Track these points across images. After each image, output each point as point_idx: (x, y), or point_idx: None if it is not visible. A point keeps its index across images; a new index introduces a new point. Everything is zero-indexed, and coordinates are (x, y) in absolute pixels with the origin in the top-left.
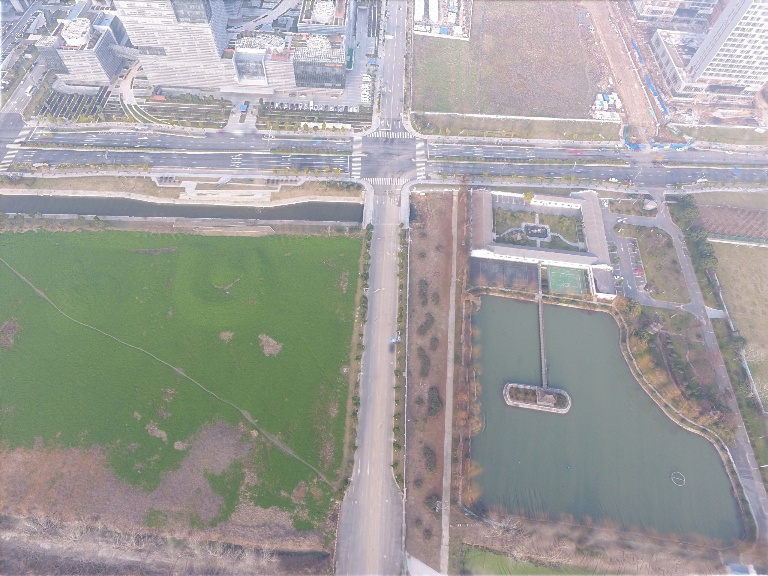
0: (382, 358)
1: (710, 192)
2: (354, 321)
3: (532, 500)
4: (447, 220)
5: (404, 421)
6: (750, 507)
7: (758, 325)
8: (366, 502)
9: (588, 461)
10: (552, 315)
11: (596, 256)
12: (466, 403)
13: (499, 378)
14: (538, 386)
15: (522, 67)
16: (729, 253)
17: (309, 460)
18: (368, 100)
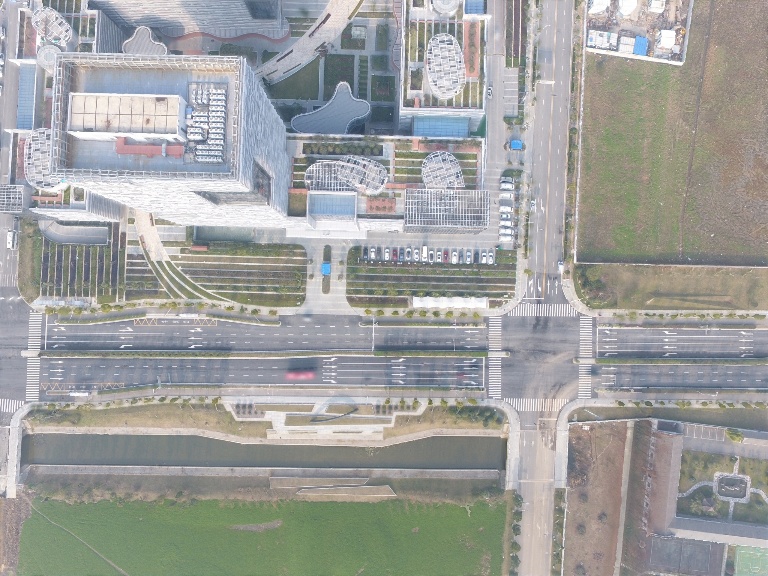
0: None
1: None
2: None
3: None
4: (616, 472)
5: None
6: None
7: None
8: None
9: None
10: None
11: None
12: None
13: None
14: None
15: (765, 136)
16: None
17: None
18: (510, 239)
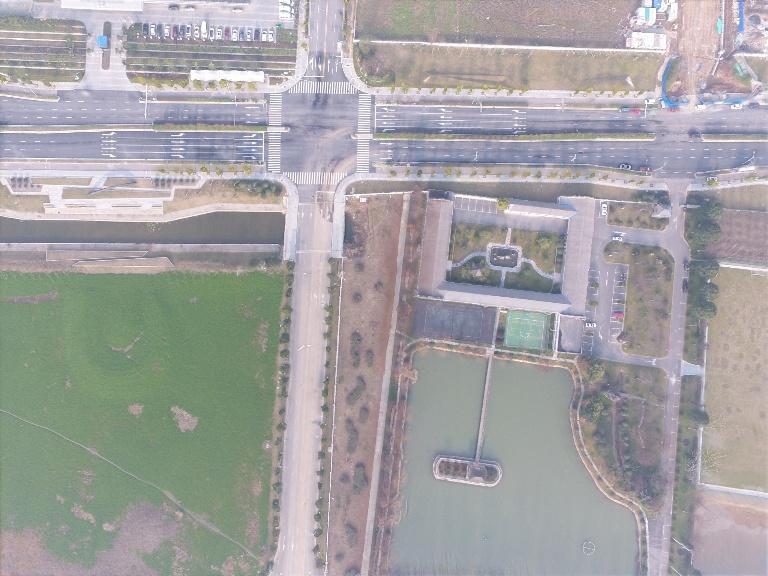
0: (307, 432)
1: (751, 186)
2: (276, 388)
3: (447, 561)
4: (392, 242)
5: (328, 499)
6: (648, 573)
7: (734, 384)
8: (290, 574)
9: (507, 530)
10: (501, 376)
11: (569, 302)
12: (385, 509)
13: (431, 450)
14: (471, 458)
15: None
16: (739, 285)
17: (235, 538)
18: (289, 16)
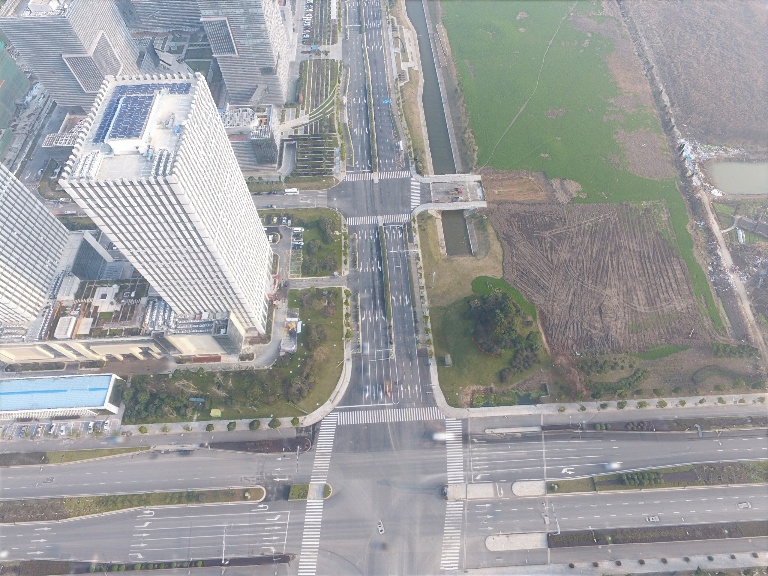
0: None
1: None
2: None
3: None
4: None
5: None
6: None
7: None
8: None
9: None
10: None
11: None
12: None
13: None
14: None
15: None
16: None
17: None
18: None
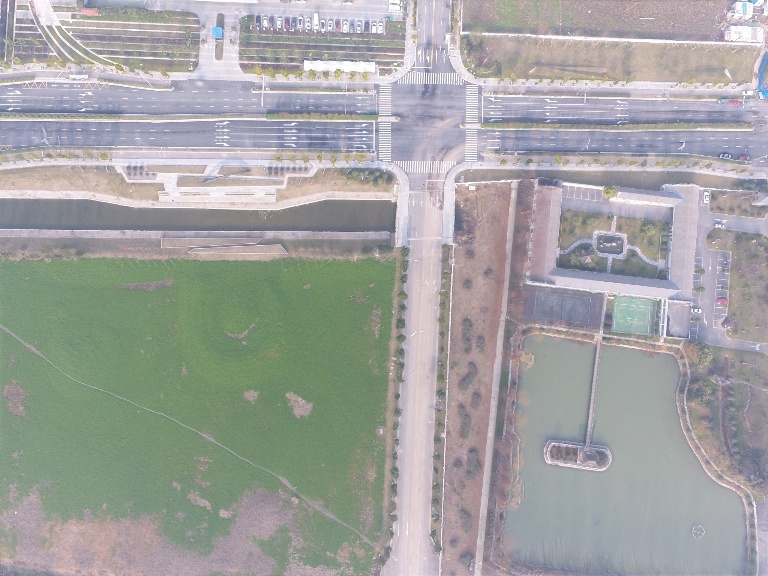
0: (420, 417)
1: None
2: (389, 374)
3: (557, 547)
4: (501, 230)
5: (442, 484)
6: (757, 557)
7: None
8: (406, 560)
9: (616, 515)
10: (609, 361)
11: (677, 288)
12: (509, 491)
13: (541, 435)
14: (581, 443)
15: None
16: None
17: (351, 524)
18: (399, 9)
